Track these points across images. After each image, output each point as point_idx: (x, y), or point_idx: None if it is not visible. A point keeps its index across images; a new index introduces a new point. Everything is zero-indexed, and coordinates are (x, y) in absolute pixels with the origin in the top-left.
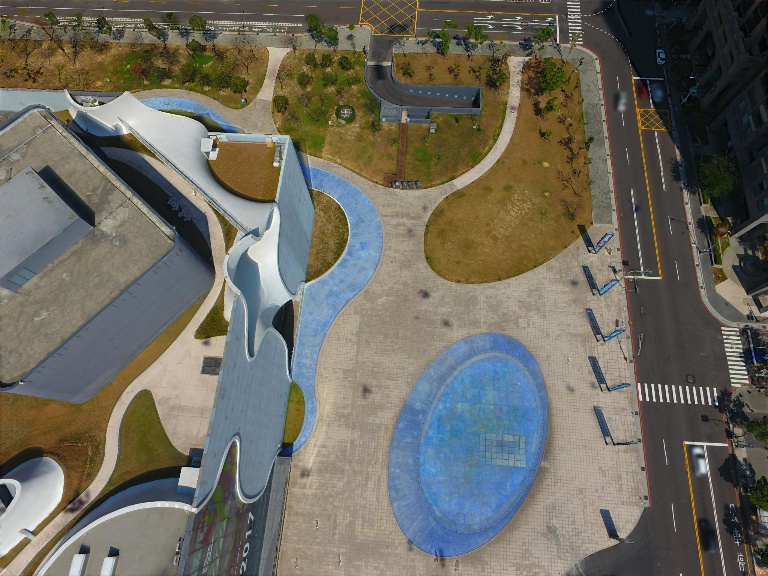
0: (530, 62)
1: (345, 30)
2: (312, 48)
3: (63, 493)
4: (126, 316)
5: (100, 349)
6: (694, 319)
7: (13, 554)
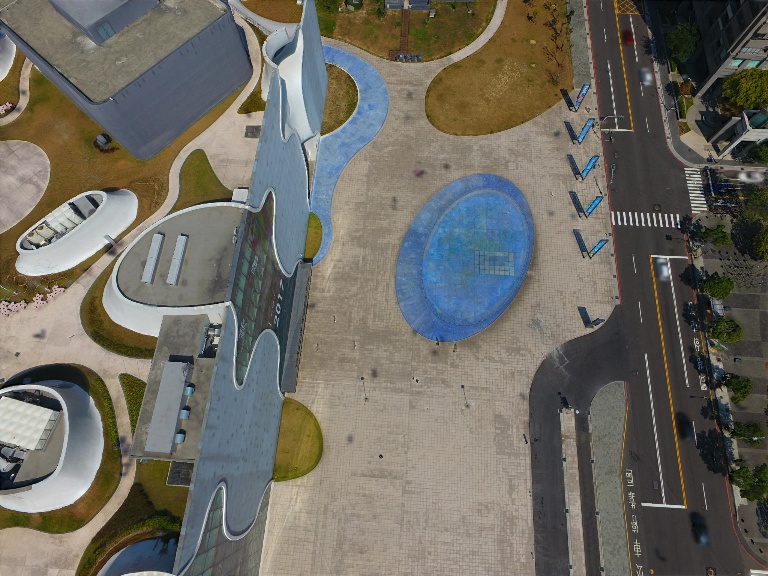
0: None
1: None
2: None
3: (137, 213)
4: (187, 71)
5: (166, 99)
6: (661, 162)
7: (99, 255)
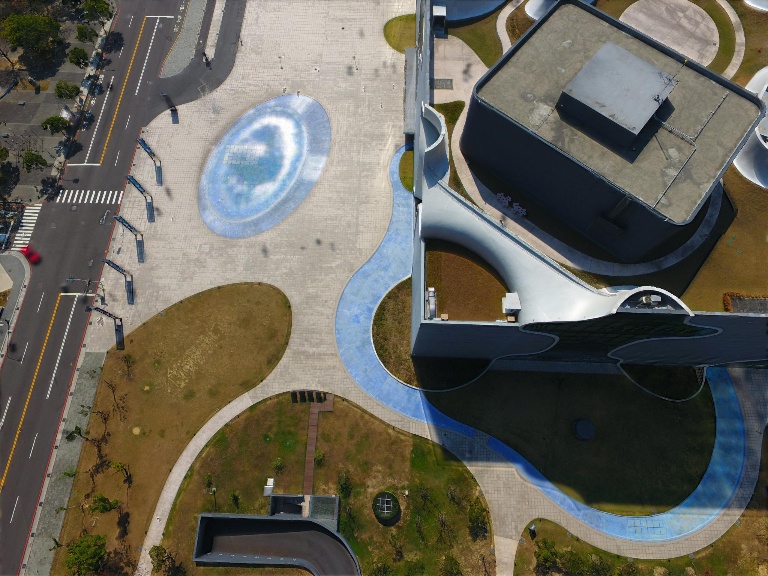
0: None
1: None
2: None
3: (524, 8)
4: None
5: None
6: (47, 257)
7: None
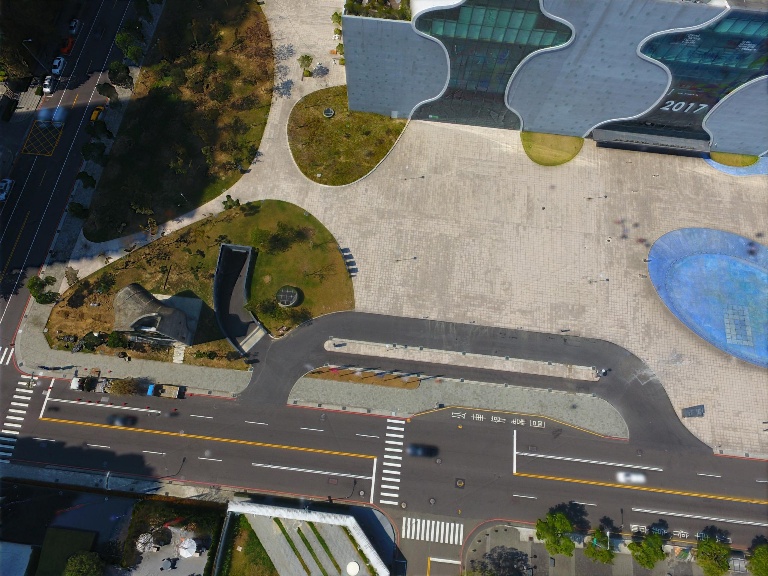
0: None
1: None
2: None
3: None
4: None
5: None
6: None
7: None
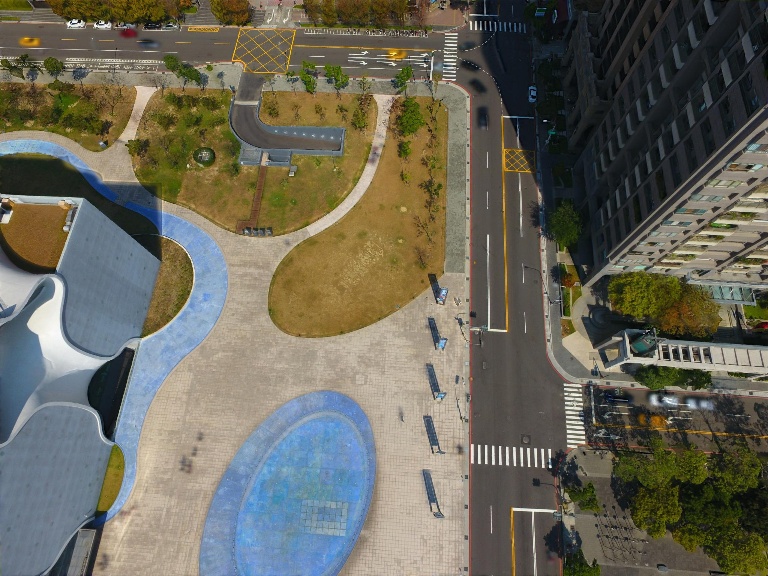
0: (399, 101)
1: (216, 67)
2: (181, 87)
3: None
4: None
5: None
6: (537, 375)
7: None
